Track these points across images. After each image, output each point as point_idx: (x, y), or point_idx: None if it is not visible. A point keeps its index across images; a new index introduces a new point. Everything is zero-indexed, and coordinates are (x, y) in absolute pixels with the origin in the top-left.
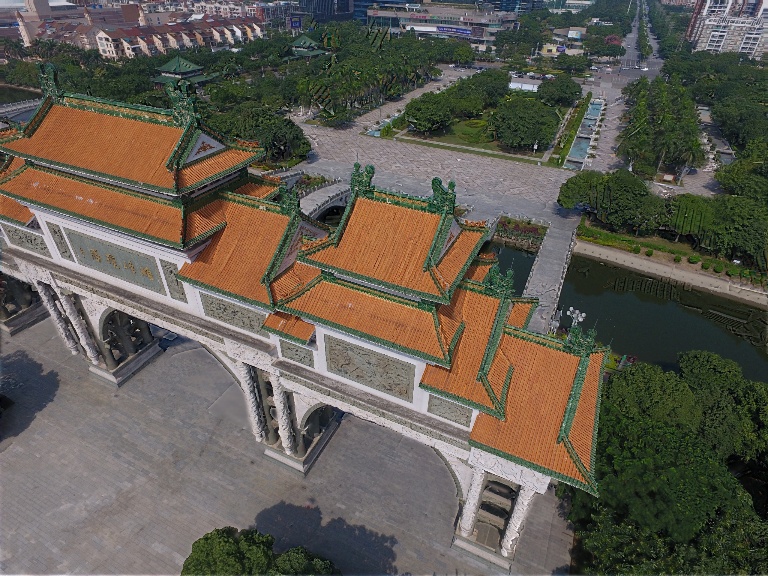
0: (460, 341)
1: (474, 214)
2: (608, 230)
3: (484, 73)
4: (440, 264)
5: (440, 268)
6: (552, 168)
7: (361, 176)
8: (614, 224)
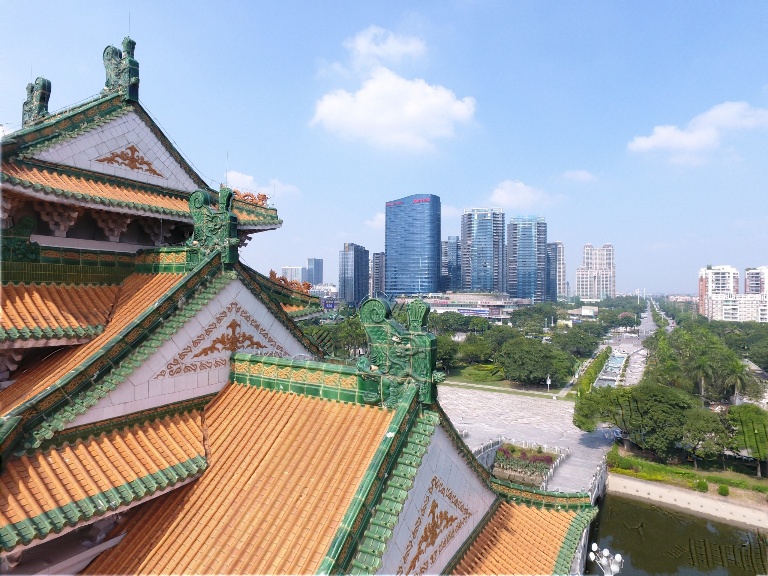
0: (61, 366)
1: (466, 440)
2: (652, 461)
3: (494, 329)
4: (64, 175)
5: (54, 177)
6: (571, 402)
7: (31, 101)
8: (657, 449)
